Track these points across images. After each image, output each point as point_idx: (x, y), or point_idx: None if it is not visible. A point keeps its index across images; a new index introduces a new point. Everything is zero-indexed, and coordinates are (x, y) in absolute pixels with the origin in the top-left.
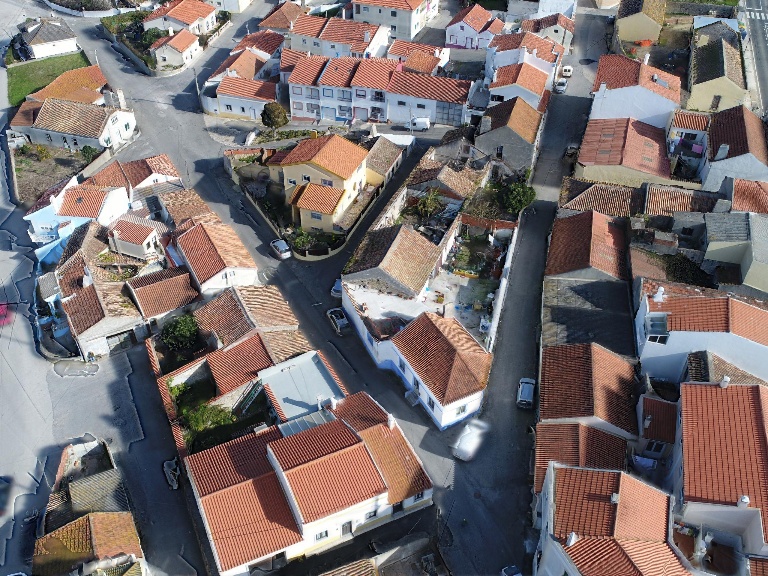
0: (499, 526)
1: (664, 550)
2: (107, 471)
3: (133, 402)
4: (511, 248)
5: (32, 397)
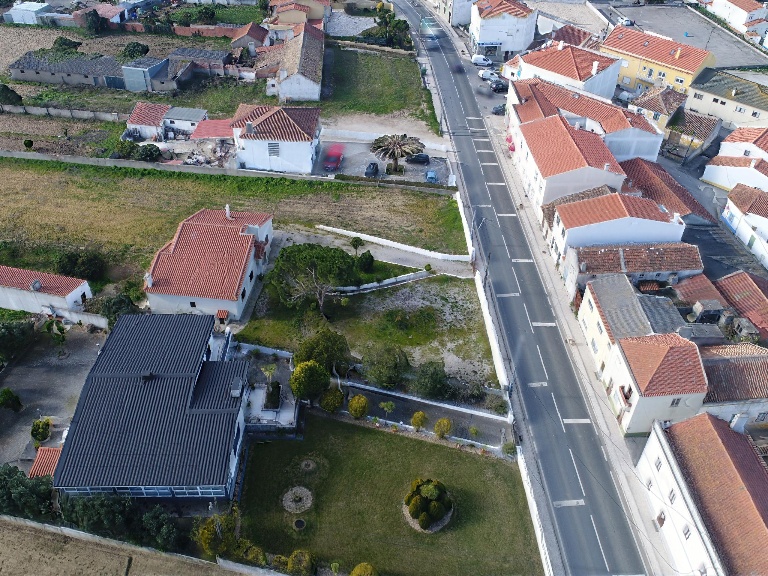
0: None
1: (599, 119)
2: None
3: None
4: None
5: None
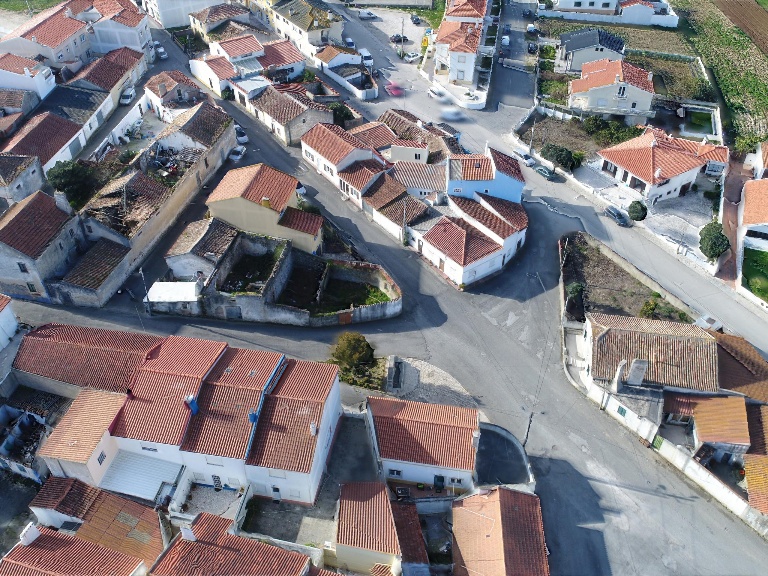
0: (164, 69)
1: None
2: (348, 76)
3: (361, 114)
4: (97, 150)
5: (421, 114)
